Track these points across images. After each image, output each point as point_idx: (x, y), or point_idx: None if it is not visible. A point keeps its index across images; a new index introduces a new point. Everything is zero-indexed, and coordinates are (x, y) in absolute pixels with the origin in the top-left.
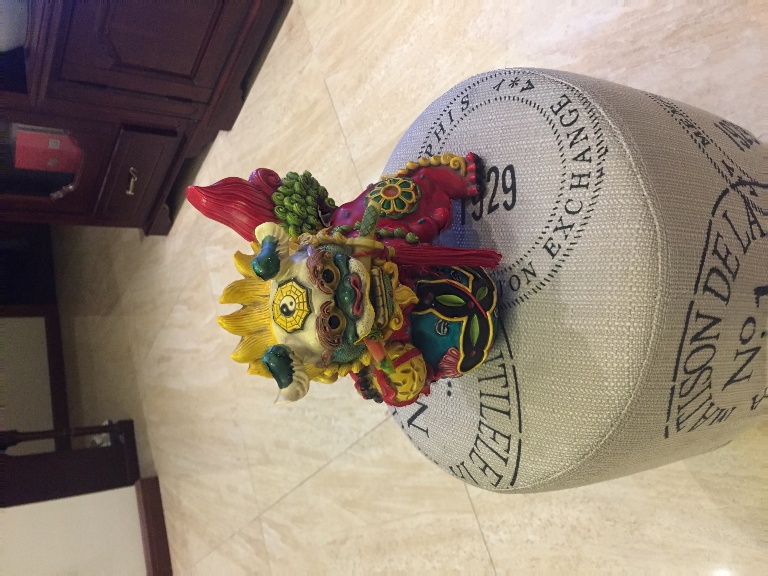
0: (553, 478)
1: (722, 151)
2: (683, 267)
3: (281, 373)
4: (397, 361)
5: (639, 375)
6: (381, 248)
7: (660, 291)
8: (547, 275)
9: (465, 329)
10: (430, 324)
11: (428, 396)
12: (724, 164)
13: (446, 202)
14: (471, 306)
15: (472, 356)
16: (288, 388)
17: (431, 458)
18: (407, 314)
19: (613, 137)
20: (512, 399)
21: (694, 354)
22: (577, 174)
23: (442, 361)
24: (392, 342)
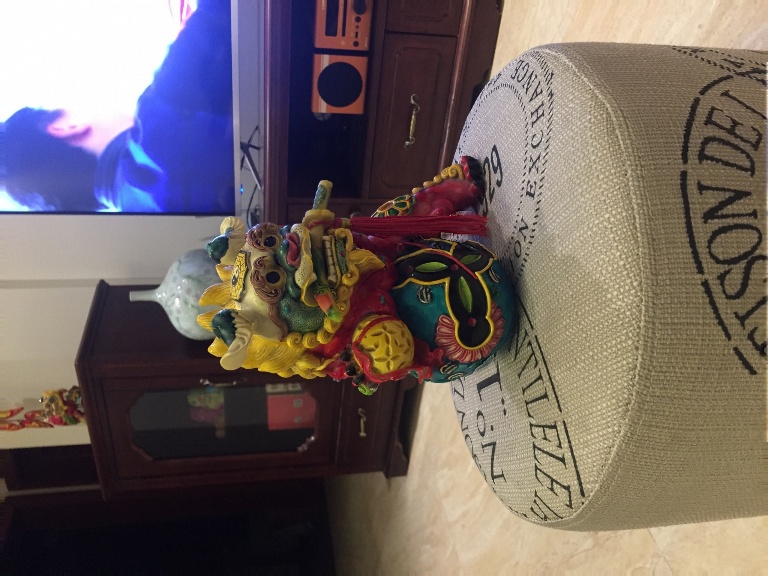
0: (612, 458)
1: (726, 54)
2: (655, 137)
3: (226, 333)
4: (367, 326)
5: (640, 270)
6: (330, 216)
7: (629, 166)
8: (534, 218)
9: (449, 290)
10: (412, 295)
11: (493, 429)
12: (726, 61)
13: (446, 205)
14: (455, 269)
15: (473, 326)
16: (231, 345)
17: (520, 512)
18: (383, 287)
19: (557, 62)
20: (544, 375)
21: (719, 236)
22: (534, 110)
23: (438, 335)
24: (367, 314)
